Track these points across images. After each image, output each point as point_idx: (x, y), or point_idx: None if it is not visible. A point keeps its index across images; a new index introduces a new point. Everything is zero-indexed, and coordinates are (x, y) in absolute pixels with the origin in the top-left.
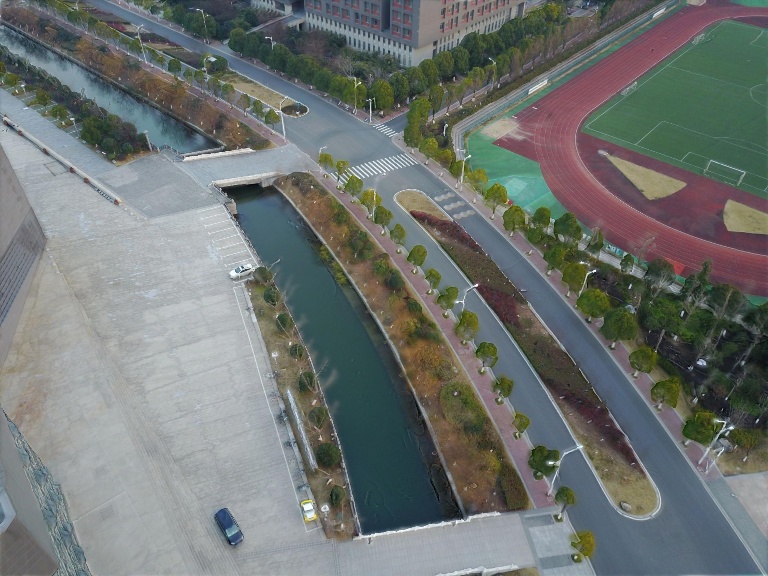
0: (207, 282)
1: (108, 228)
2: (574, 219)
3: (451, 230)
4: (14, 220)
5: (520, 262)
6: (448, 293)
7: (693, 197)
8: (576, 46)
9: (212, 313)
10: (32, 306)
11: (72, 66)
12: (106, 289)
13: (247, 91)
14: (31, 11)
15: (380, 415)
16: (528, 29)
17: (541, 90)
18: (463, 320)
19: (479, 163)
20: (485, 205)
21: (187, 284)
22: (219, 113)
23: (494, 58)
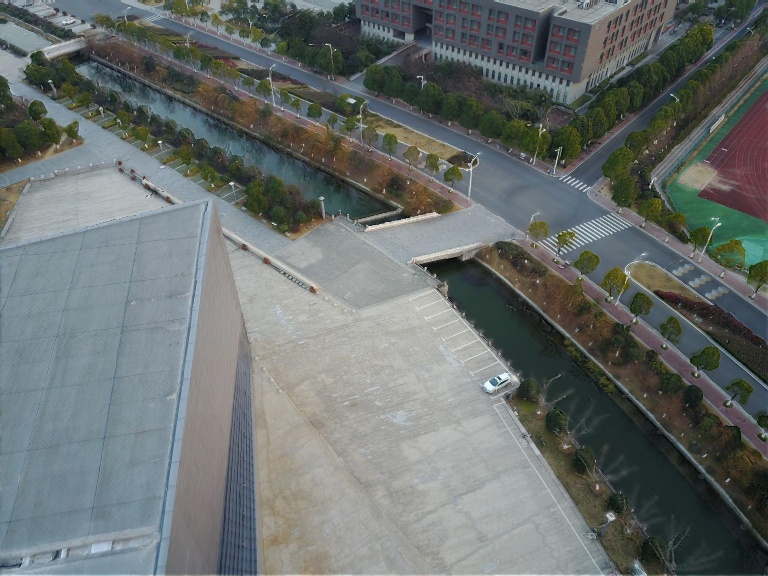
0: (459, 398)
1: (315, 325)
2: None
3: (717, 317)
4: (236, 334)
5: None
6: None
7: None
8: (740, 73)
9: (483, 443)
10: (266, 441)
11: (184, 109)
12: (344, 413)
13: (400, 138)
14: (126, 46)
15: (709, 572)
16: (686, 55)
17: (720, 127)
18: None
19: (695, 222)
20: (736, 280)
21: (437, 402)
22: (380, 167)
23: (676, 94)
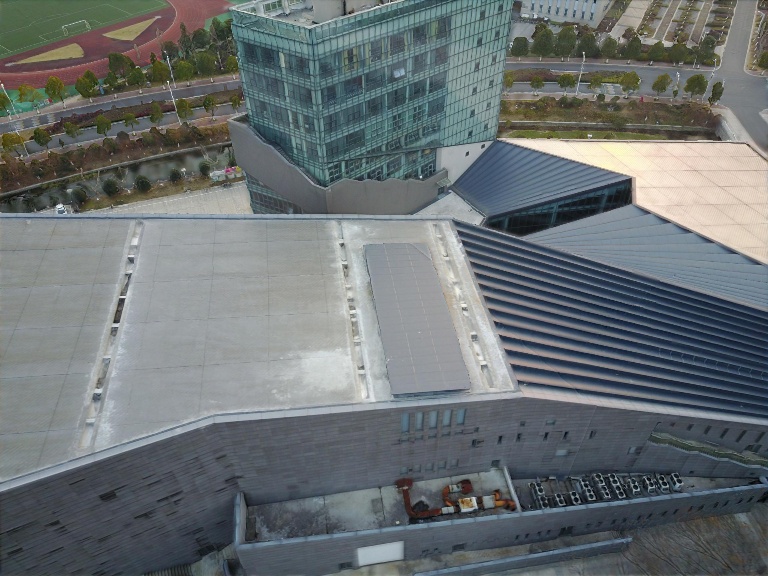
0: None
1: None
2: (118, 53)
3: (71, 120)
4: None
5: (123, 101)
6: (155, 108)
7: (91, 44)
8: None
9: None
10: None
11: None
12: None
13: None
14: None
15: None
16: None
17: None
18: (185, 102)
19: None
20: None
21: None
22: None
23: None
